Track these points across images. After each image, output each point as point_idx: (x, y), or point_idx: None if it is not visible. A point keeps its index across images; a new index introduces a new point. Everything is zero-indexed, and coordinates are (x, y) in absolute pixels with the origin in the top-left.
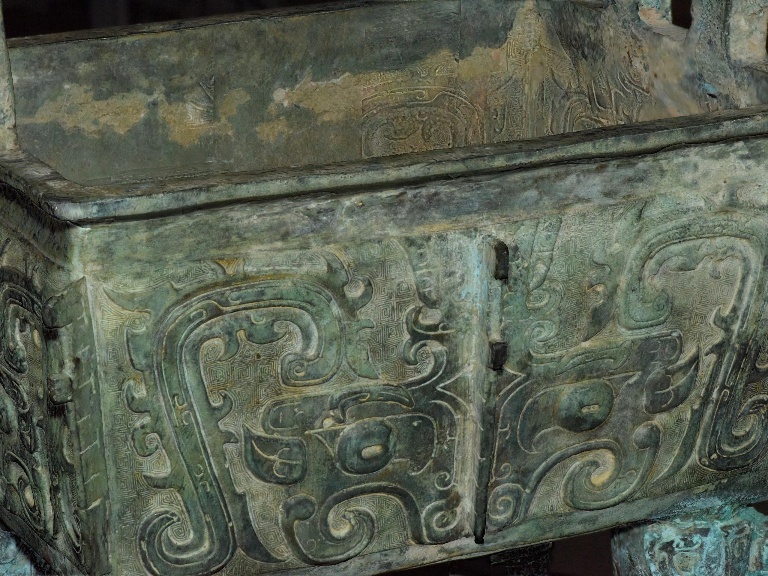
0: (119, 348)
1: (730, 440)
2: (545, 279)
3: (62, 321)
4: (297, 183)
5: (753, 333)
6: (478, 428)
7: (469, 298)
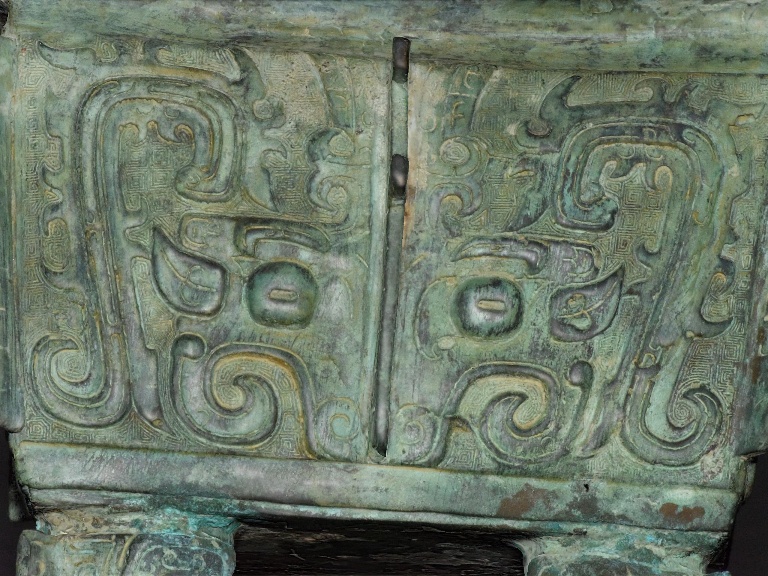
0: None
1: None
2: None
3: None
4: None
5: None
6: None
7: None
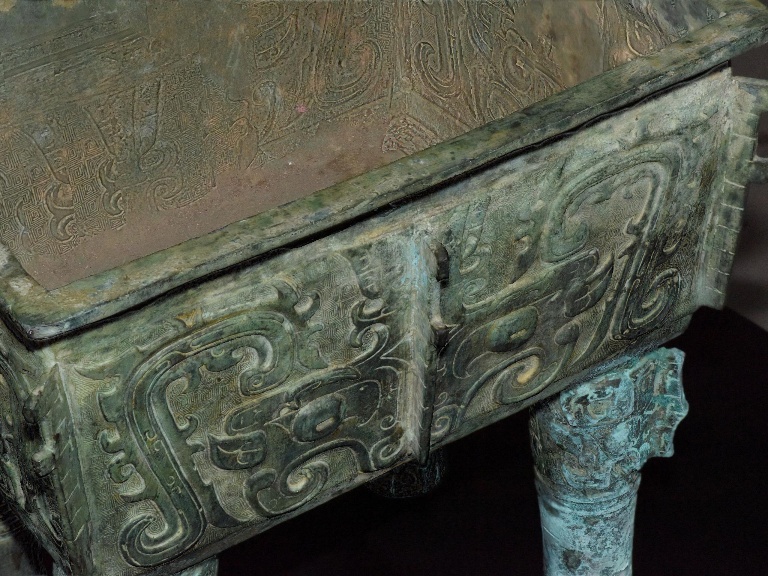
0: (92, 409)
1: (640, 314)
2: (476, 248)
3: (42, 414)
4: (251, 250)
5: (661, 230)
6: (420, 382)
7: (408, 282)
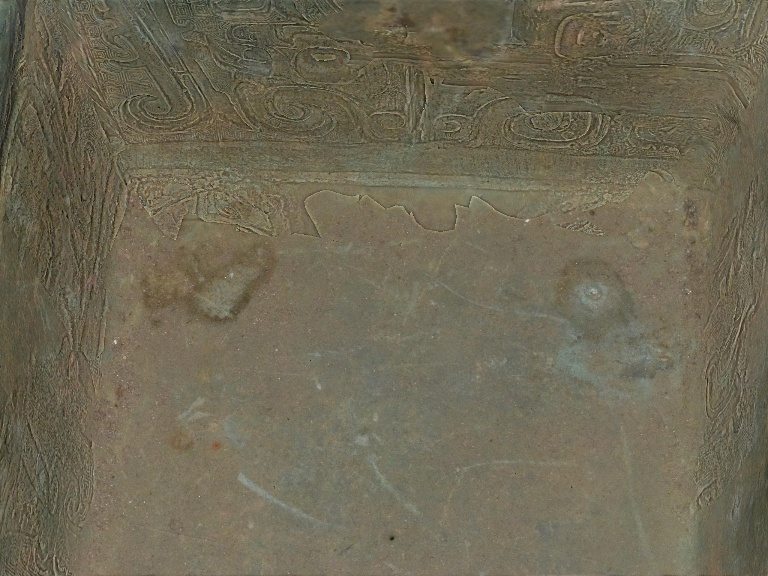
0: None
1: None
2: None
3: None
4: None
5: None
6: None
7: None
